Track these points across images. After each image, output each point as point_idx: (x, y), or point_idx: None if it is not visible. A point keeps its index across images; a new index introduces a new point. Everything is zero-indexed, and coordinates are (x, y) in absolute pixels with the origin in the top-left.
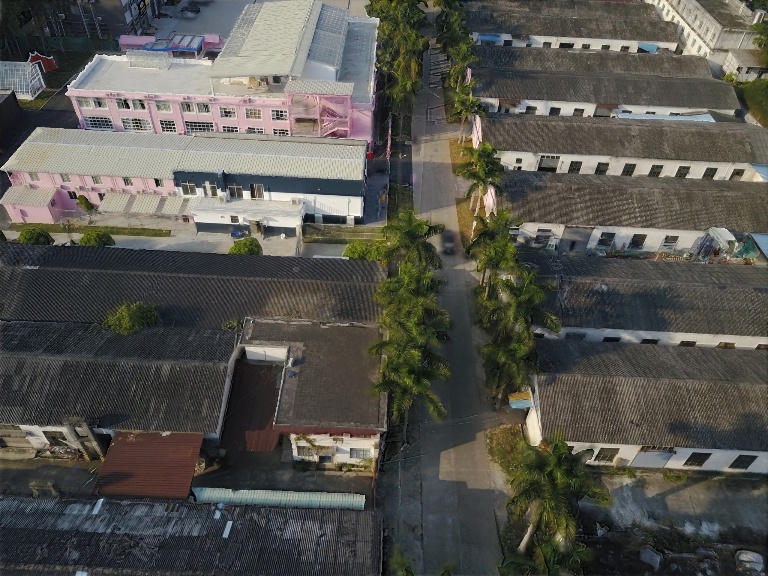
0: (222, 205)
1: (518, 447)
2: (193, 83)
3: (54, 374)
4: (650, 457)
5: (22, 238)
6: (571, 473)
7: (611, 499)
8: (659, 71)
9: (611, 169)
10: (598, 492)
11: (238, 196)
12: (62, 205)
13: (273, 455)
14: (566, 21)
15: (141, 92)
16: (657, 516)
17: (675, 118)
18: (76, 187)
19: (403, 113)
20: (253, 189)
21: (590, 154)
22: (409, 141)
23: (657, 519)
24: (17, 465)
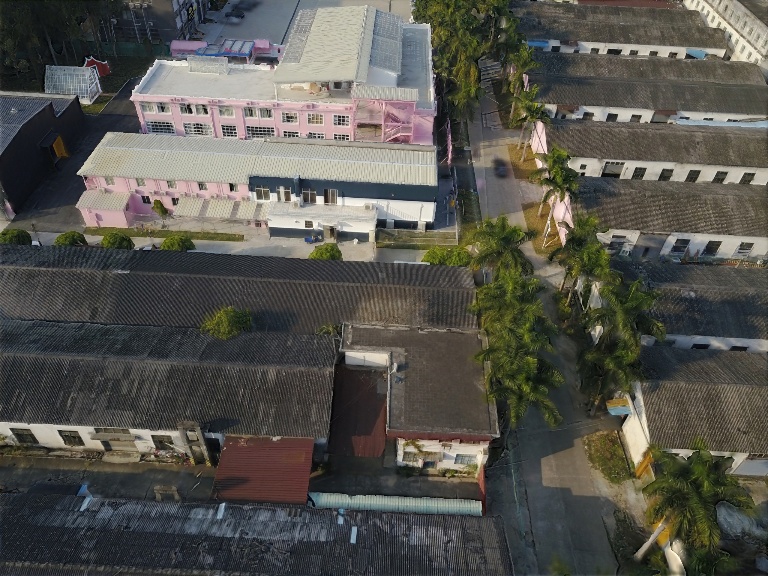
0: (296, 210)
1: (617, 454)
2: (254, 88)
3: (162, 378)
4: (755, 465)
5: (106, 242)
6: (718, 481)
7: (717, 507)
8: (712, 77)
9: (675, 175)
10: (742, 500)
11: (311, 201)
12: (135, 209)
13: (375, 460)
14: (614, 27)
15: (205, 97)
16: (765, 524)
17: (734, 125)
18: (151, 191)
19: (463, 119)
20: (327, 194)
21: (655, 160)
22: (468, 147)
23: (766, 527)
24: (123, 469)
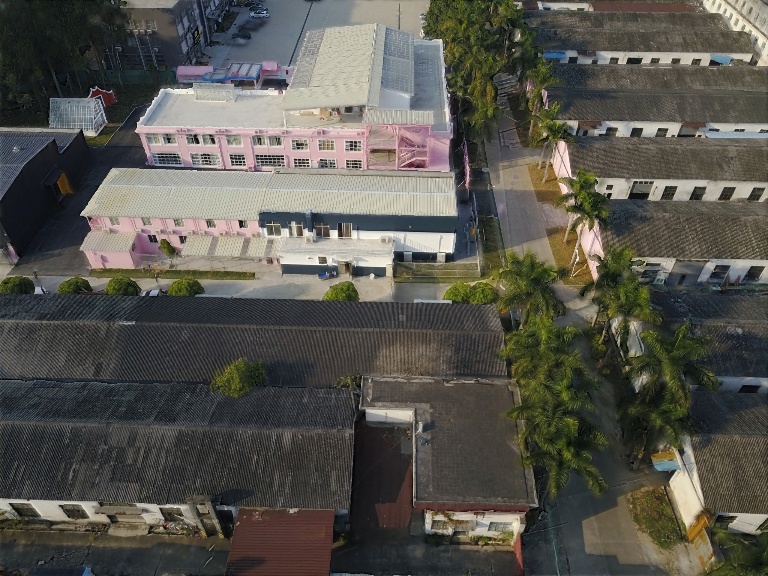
0: (309, 246)
1: (666, 514)
2: (262, 115)
3: (169, 445)
4: None
5: (111, 289)
6: None
7: None
8: (741, 85)
9: (708, 193)
10: None
11: (324, 235)
12: (141, 249)
13: None
14: (633, 35)
15: (212, 127)
16: None
17: None
18: (157, 230)
19: (481, 139)
20: (340, 228)
21: (687, 178)
22: (486, 168)
23: None
24: (131, 543)
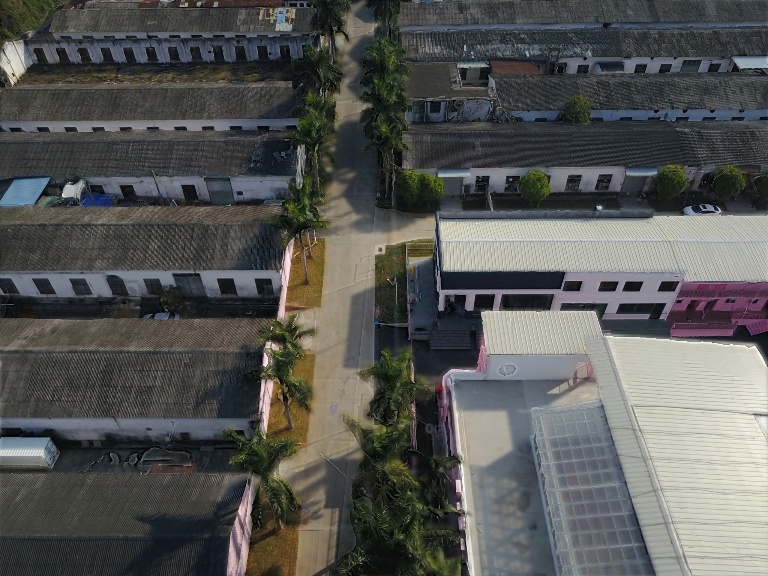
0: None
1: None
2: None
3: None
4: None
5: None
6: None
7: None
8: None
9: None
10: None
11: None
12: None
13: None
14: None
15: None
16: None
17: None
18: None
19: None
20: None
21: (116, 319)
22: None
23: None
24: None
